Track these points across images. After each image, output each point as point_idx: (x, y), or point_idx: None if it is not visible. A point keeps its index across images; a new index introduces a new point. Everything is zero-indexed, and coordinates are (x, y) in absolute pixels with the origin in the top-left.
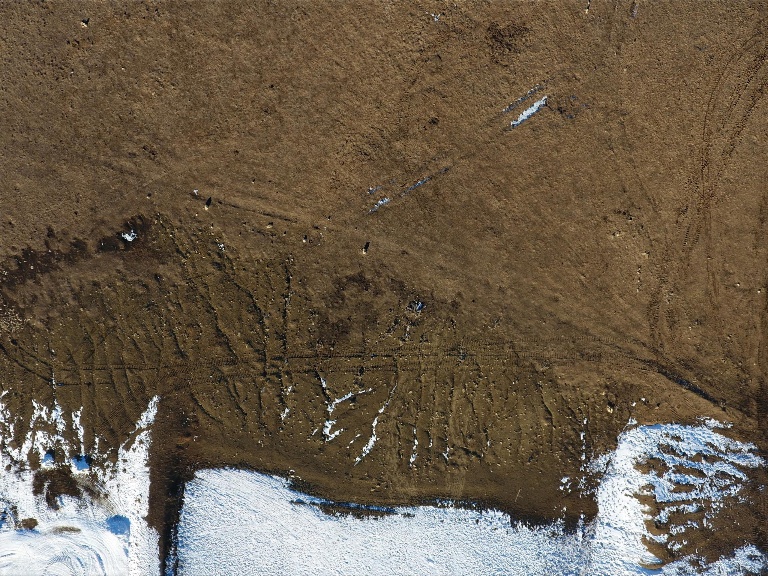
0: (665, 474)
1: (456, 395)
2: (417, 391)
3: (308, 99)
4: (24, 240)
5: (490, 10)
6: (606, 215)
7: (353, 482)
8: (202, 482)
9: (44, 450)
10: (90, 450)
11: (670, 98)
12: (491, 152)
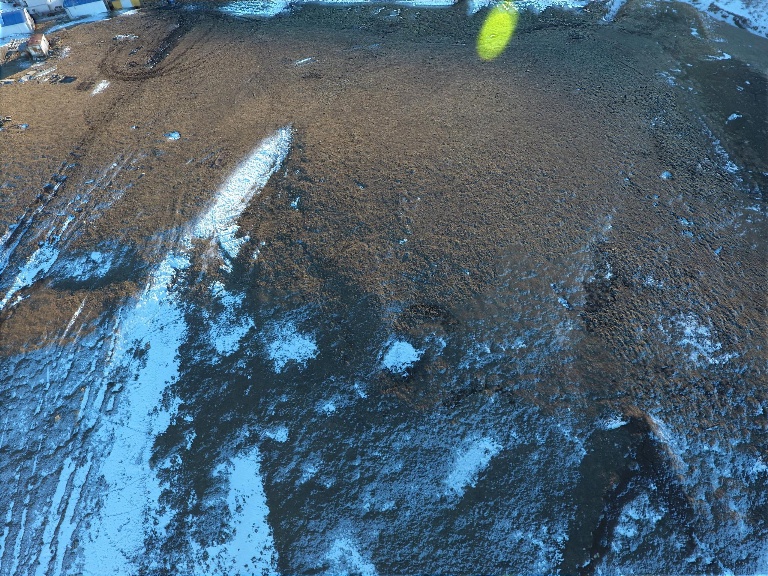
0: (262, 5)
1: None
2: None
3: None
4: None
5: None
6: None
7: None
8: None
9: None
10: None
11: None
12: None
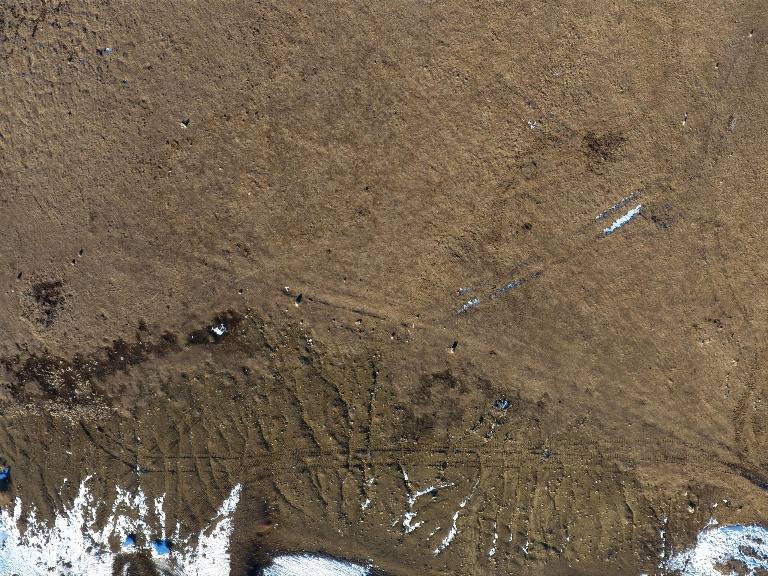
0: (746, 575)
1: (538, 492)
2: (500, 487)
3: (402, 201)
4: (116, 332)
5: (587, 119)
6: (696, 323)
7: (432, 573)
8: (281, 569)
9: (125, 534)
10: (171, 535)
11: (766, 212)
12: (583, 258)
